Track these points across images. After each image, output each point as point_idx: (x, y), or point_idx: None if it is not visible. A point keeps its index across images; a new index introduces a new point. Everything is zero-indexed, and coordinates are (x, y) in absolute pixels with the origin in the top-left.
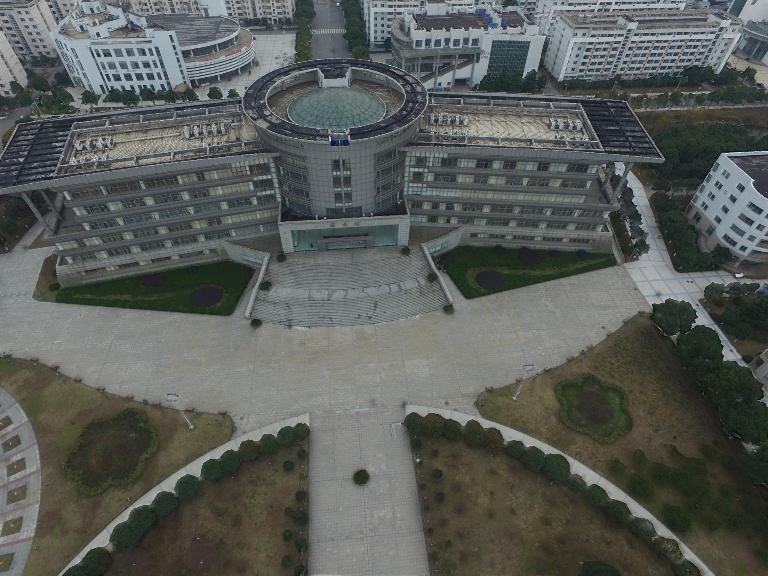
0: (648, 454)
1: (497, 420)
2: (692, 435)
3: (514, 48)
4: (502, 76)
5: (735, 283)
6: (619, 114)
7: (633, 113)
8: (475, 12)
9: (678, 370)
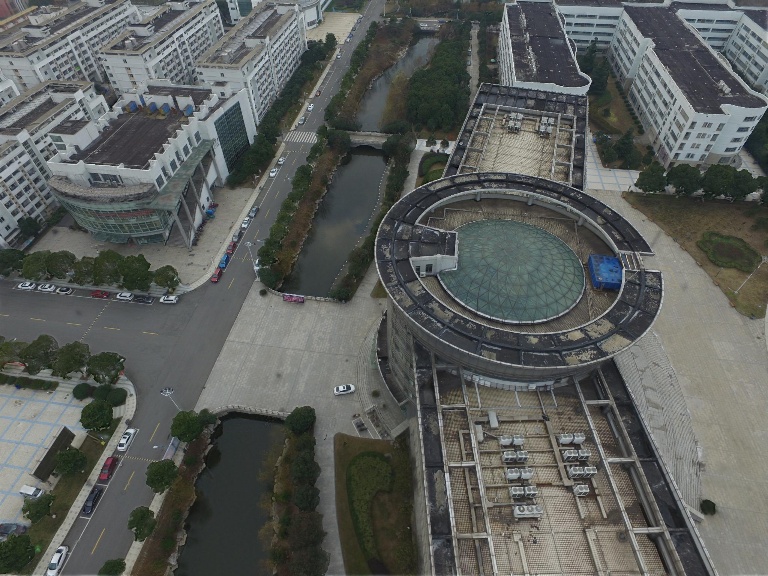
0: (760, 240)
1: (763, 309)
2: (736, 216)
3: (231, 117)
4: (256, 150)
5: (607, 143)
6: (504, 93)
7: (507, 86)
8: (122, 111)
9: (679, 201)
